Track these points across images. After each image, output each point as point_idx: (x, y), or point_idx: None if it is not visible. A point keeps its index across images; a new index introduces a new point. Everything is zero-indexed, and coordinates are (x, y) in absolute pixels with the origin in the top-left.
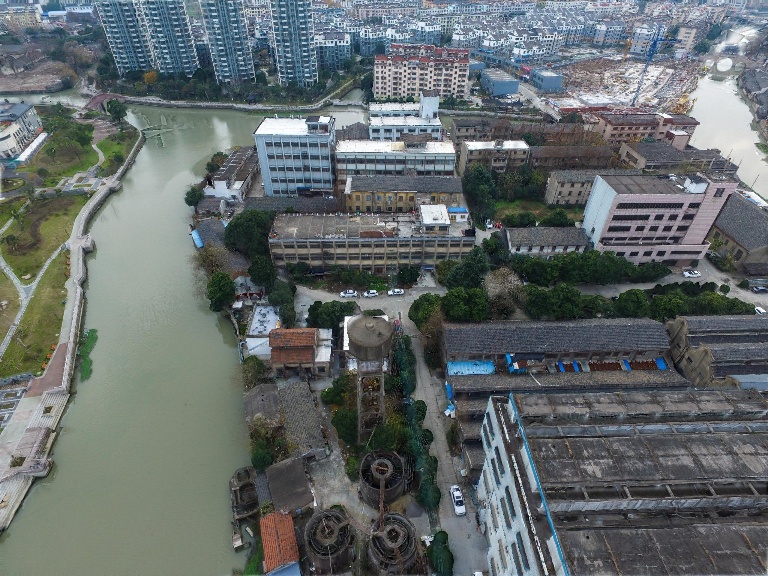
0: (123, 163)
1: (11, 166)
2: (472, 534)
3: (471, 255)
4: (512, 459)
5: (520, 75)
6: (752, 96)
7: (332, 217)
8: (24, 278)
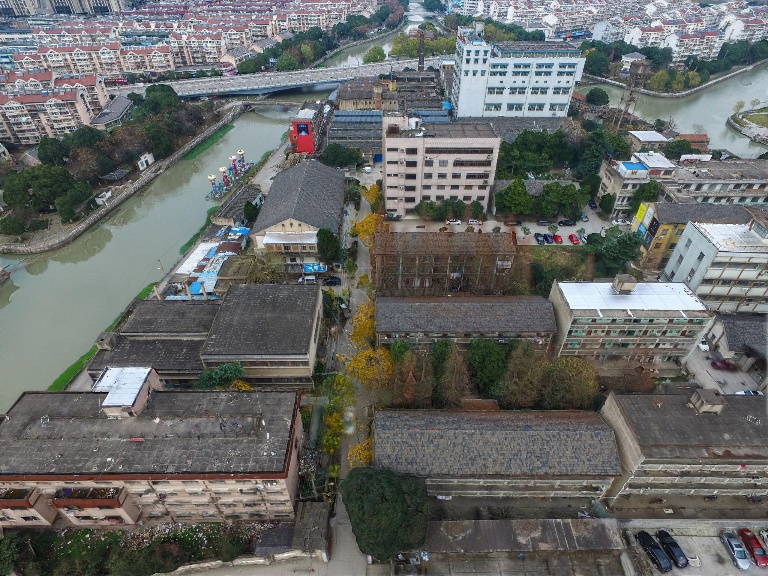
0: None
1: None
2: None
3: None
4: None
5: None
6: None
7: (763, 176)
8: None
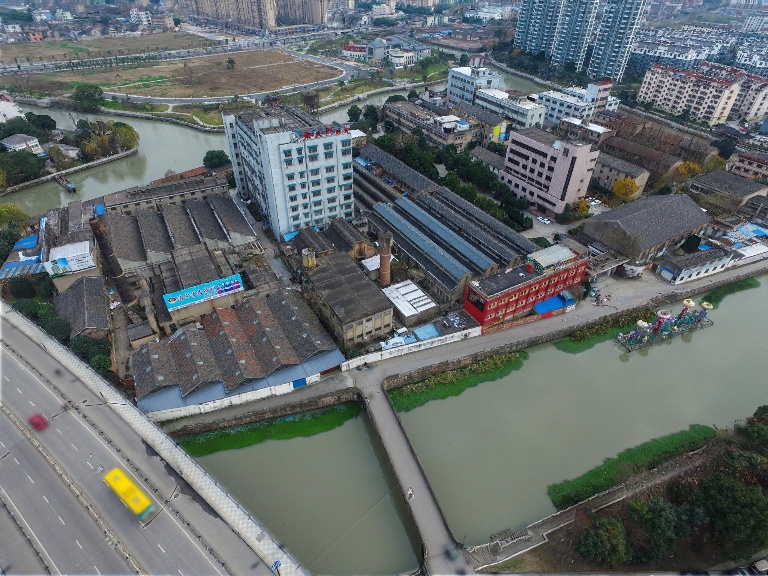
0: (427, 82)
1: None
2: None
3: None
4: None
5: None
6: None
7: (420, 108)
8: (331, 96)
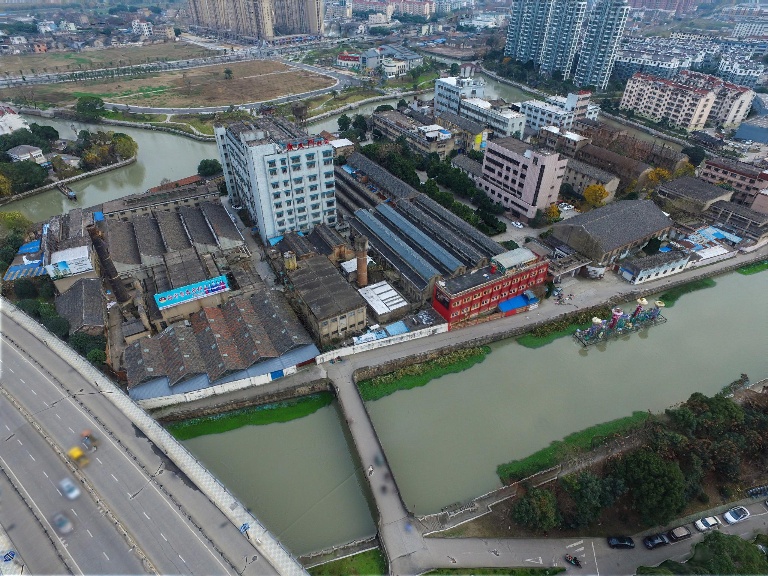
0: (418, 91)
1: (384, 79)
2: None
3: None
4: None
5: None
6: None
7: None
8: (324, 105)
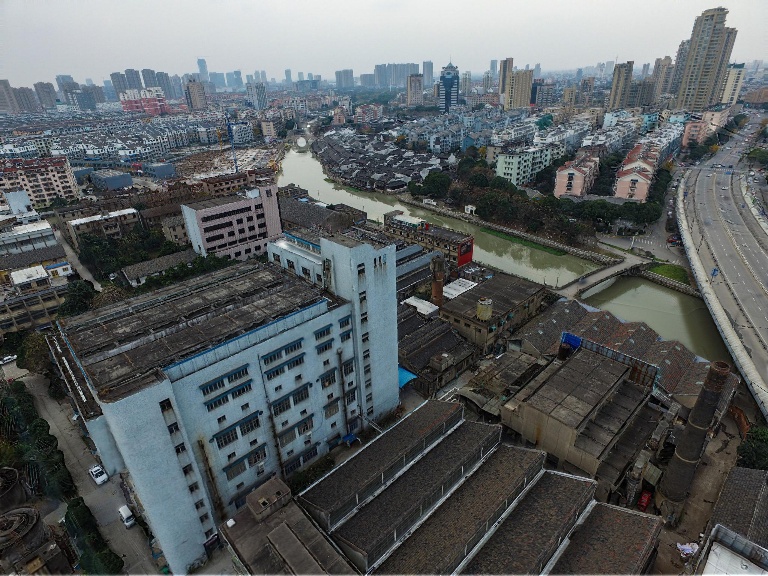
0: None
1: None
2: (117, 489)
3: (70, 288)
4: (62, 359)
5: (134, 171)
6: (319, 155)
7: None
8: None
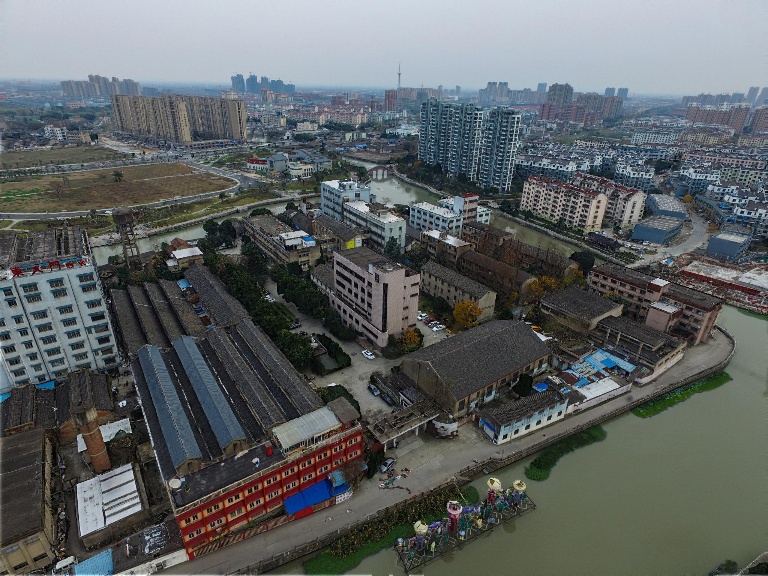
0: (319, 193)
1: (288, 181)
2: None
3: None
4: None
5: None
6: None
7: None
8: None
